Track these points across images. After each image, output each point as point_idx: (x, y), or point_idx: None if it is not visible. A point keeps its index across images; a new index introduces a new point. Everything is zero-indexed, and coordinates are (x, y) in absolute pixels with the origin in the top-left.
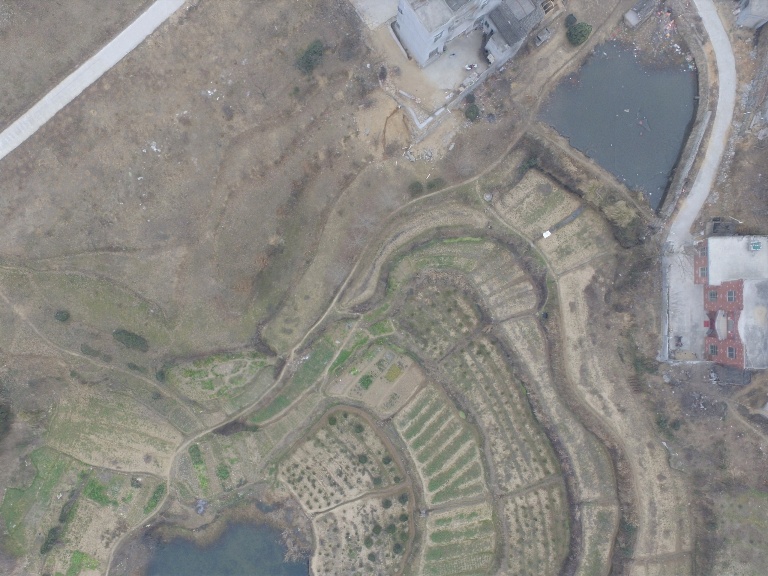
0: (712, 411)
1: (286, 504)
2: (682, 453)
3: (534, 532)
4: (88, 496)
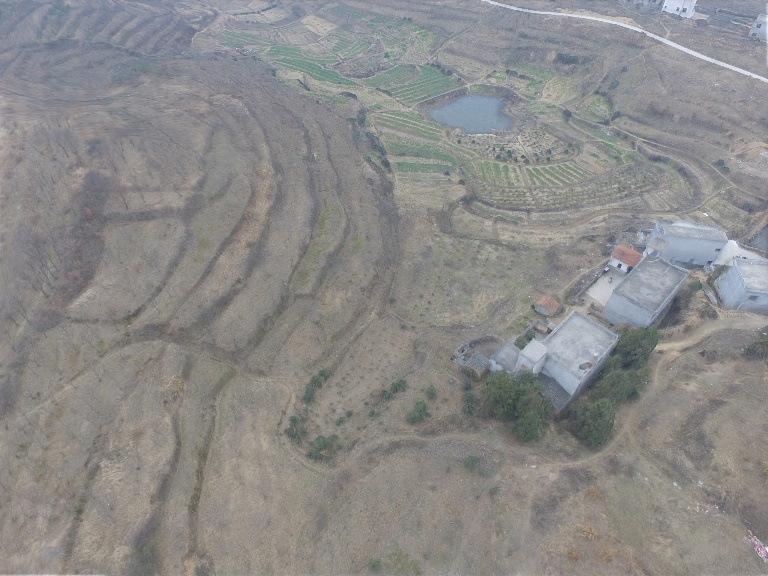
0: None
1: None
2: None
3: None
4: (531, 82)
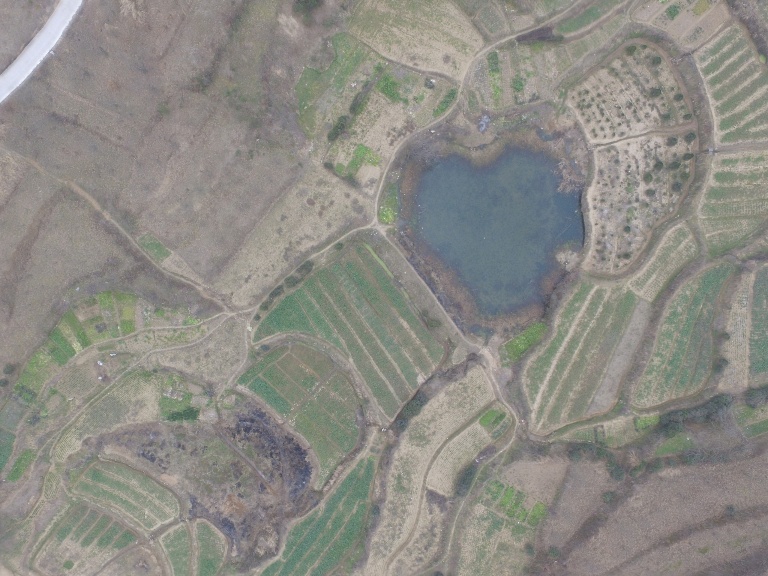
0: None
1: (567, 134)
2: None
3: None
4: (381, 90)
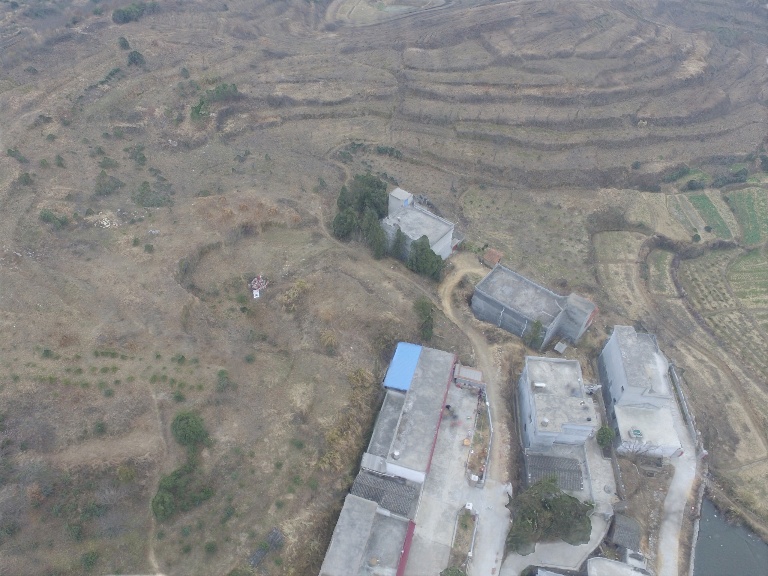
0: None
1: None
2: None
3: None
4: None
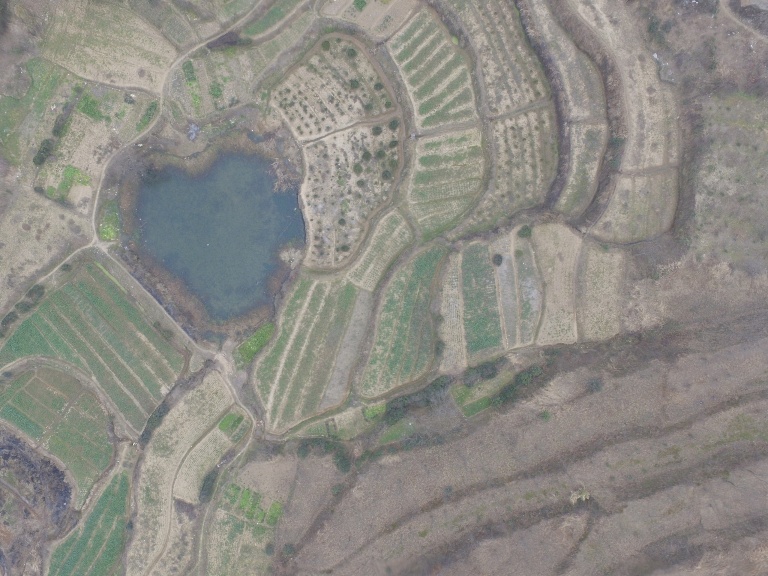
0: (704, 6)
1: (277, 134)
2: (672, 62)
3: (523, 155)
4: (82, 110)
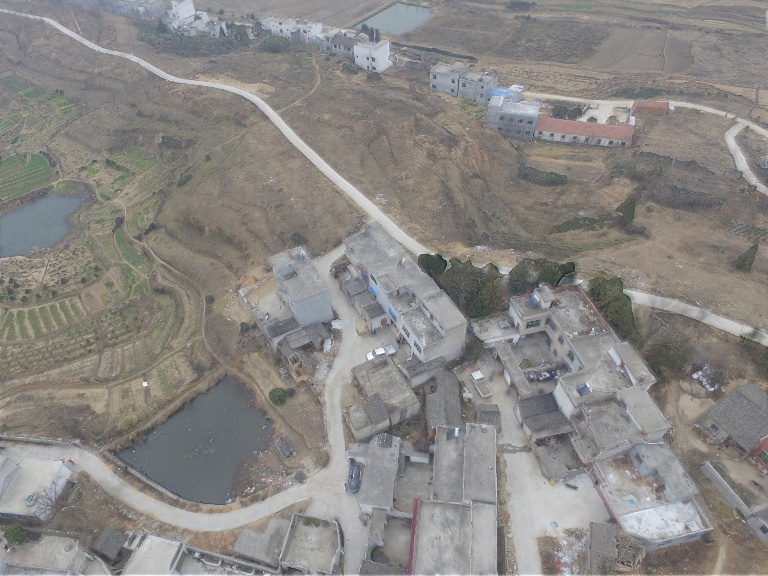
0: None
1: None
2: None
3: None
4: (123, 175)
